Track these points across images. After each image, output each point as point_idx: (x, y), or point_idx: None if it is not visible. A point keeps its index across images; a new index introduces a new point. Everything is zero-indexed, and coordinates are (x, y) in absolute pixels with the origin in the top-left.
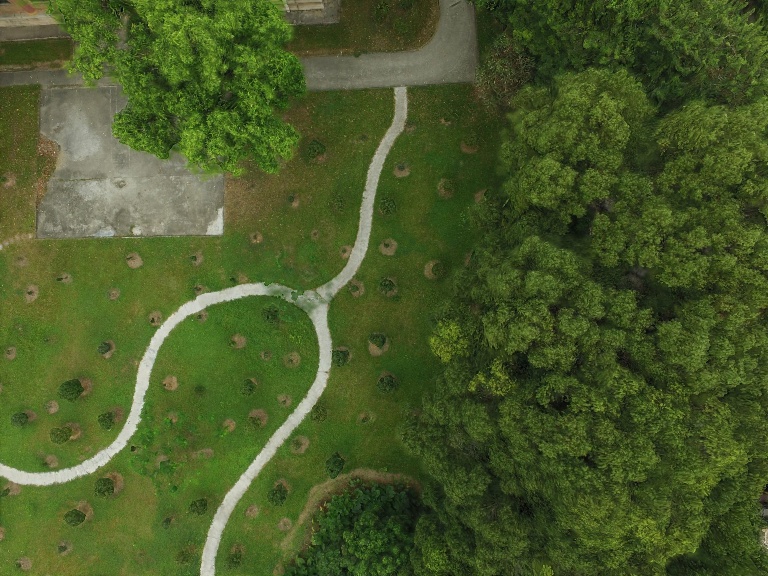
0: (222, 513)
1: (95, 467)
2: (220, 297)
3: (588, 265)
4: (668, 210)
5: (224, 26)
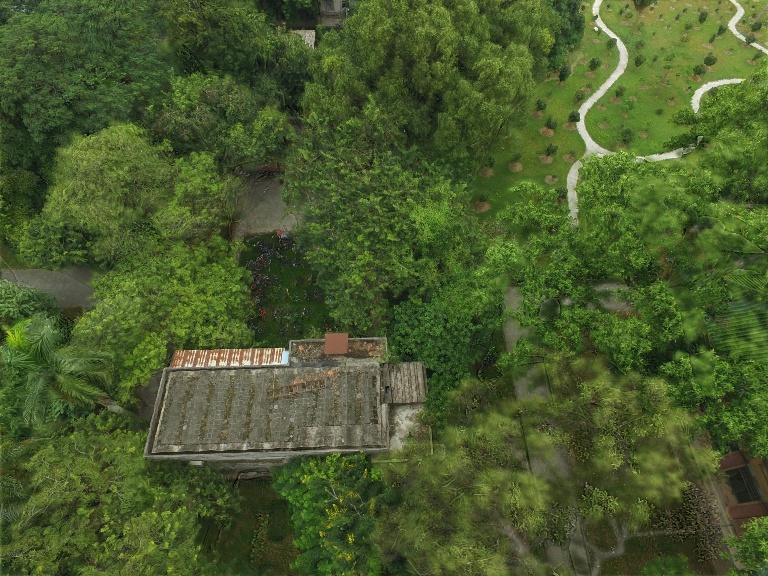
0: (623, 67)
1: (709, 84)
2: (665, 156)
3: (490, 26)
4: (472, 6)
5: (759, 72)
